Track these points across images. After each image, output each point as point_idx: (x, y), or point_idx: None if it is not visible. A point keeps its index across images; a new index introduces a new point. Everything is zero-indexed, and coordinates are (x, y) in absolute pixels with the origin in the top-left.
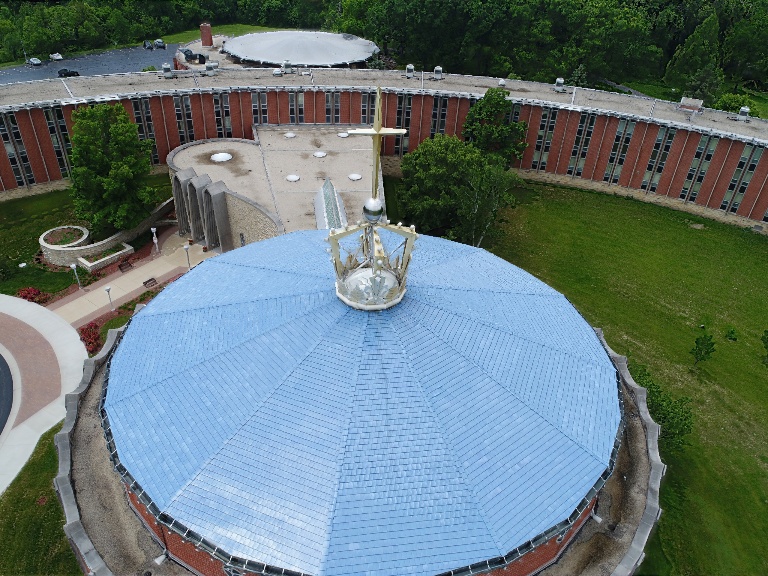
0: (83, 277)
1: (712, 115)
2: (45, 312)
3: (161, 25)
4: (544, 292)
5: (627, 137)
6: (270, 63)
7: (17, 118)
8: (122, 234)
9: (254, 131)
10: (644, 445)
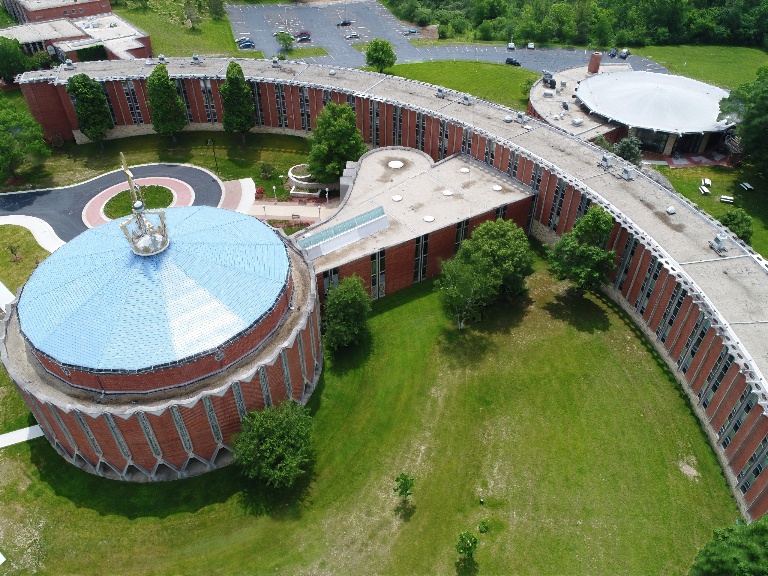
0: (285, 197)
1: None
2: (250, 203)
3: (655, 35)
4: (238, 316)
5: (703, 330)
6: (587, 106)
7: (333, 95)
8: (322, 184)
9: (450, 156)
10: None
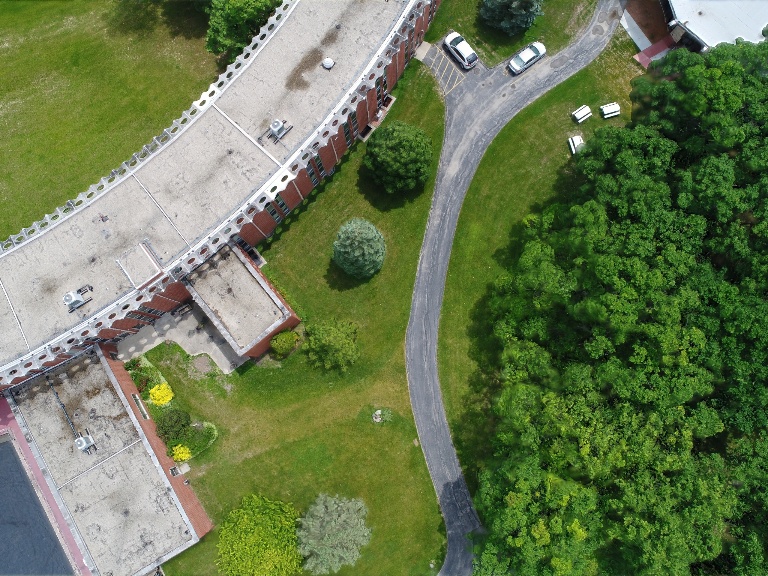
0: None
1: (109, 276)
2: None
3: None
4: None
5: None
6: None
7: None
8: None
9: None
10: None
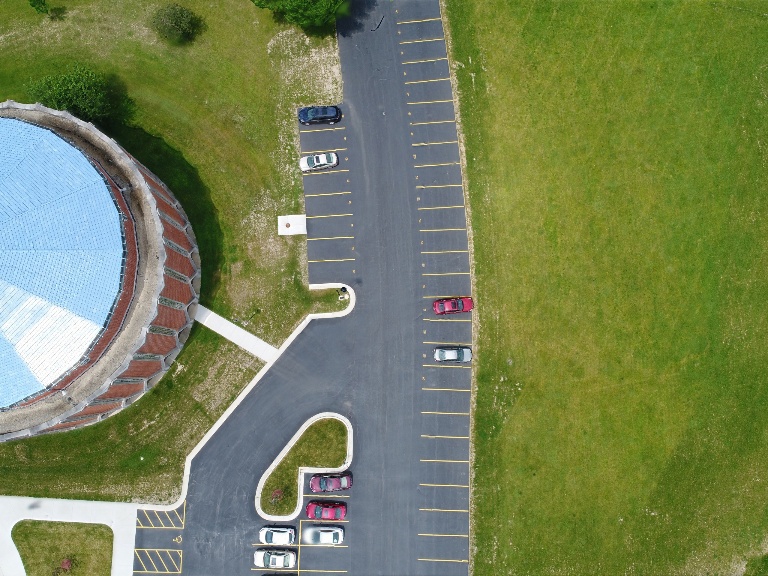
0: None
1: None
2: None
3: None
4: None
5: None
6: None
7: None
8: None
9: None
10: (97, 137)
